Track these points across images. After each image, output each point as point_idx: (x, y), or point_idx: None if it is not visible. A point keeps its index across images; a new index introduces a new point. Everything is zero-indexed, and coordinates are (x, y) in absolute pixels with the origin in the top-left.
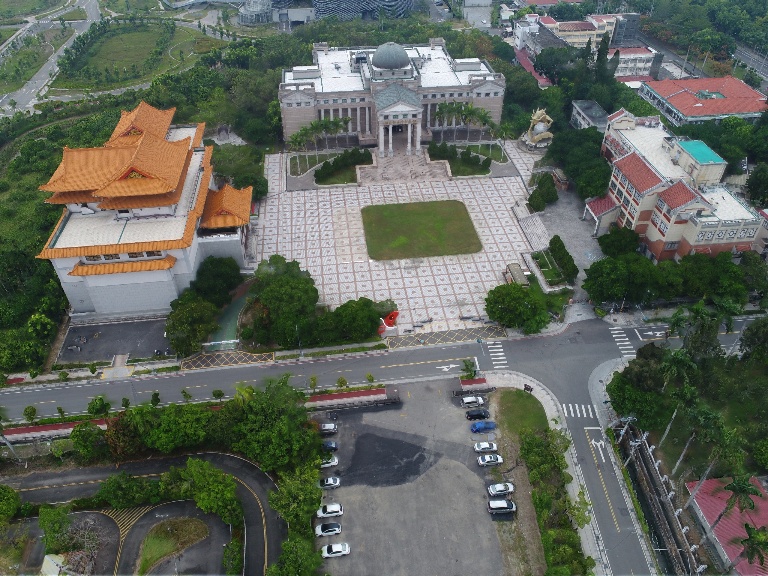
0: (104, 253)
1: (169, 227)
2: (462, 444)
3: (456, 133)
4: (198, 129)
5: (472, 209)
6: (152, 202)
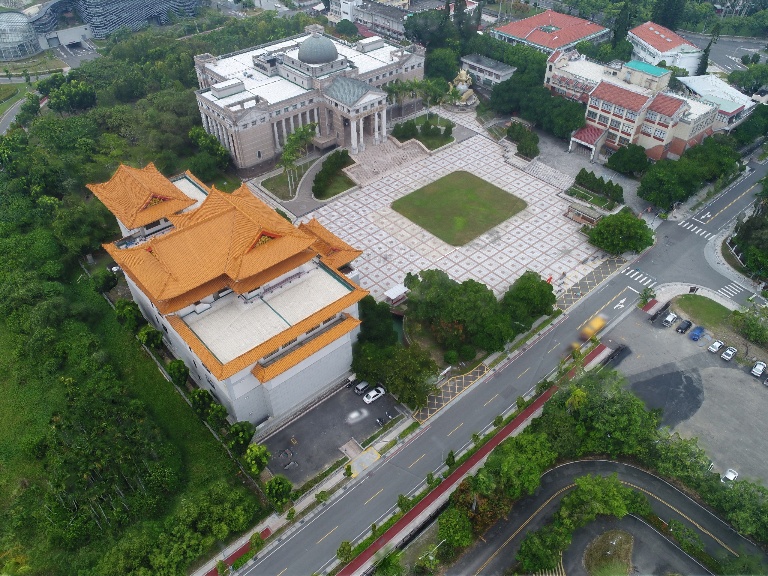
0: (289, 340)
1: (318, 285)
2: (699, 353)
3: None
4: (193, 179)
5: (479, 173)
6: (289, 264)
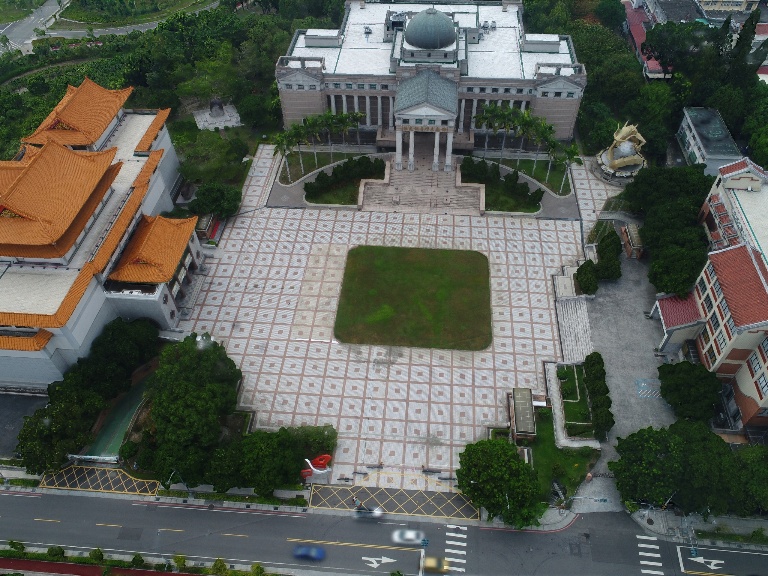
0: None
1: (52, 286)
2: None
3: (510, 139)
4: (156, 119)
5: (496, 271)
6: (32, 251)
